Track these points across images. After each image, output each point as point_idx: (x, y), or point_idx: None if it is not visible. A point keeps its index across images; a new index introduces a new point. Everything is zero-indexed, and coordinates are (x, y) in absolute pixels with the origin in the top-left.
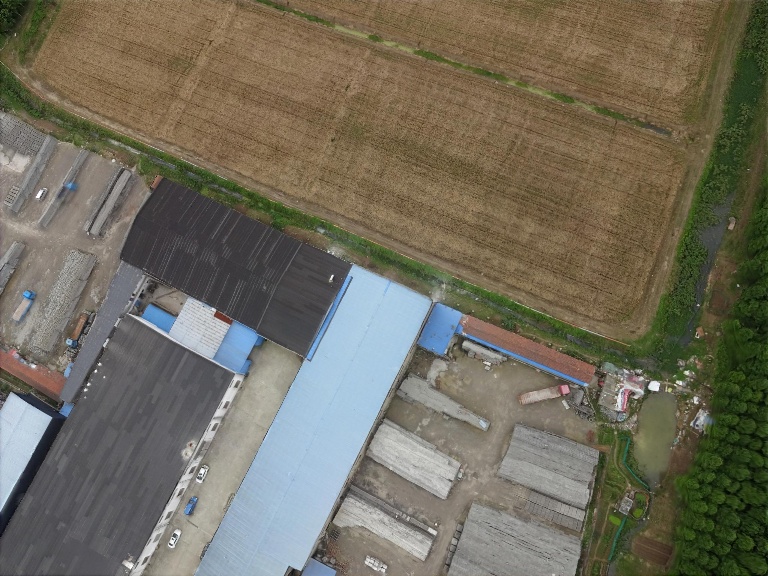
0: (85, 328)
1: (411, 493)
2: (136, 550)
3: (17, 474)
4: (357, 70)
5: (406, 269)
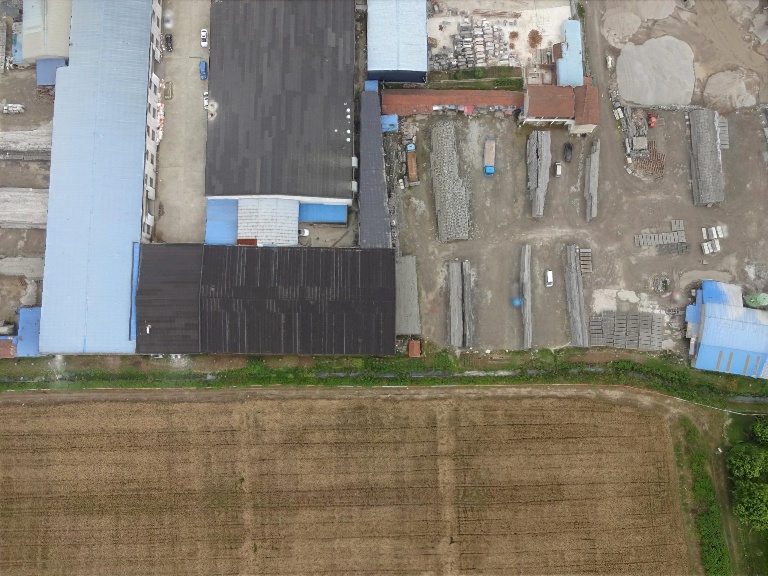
0: (406, 168)
1: (8, 179)
2: (216, 8)
3: (372, 8)
4: (254, 575)
5: (103, 376)
